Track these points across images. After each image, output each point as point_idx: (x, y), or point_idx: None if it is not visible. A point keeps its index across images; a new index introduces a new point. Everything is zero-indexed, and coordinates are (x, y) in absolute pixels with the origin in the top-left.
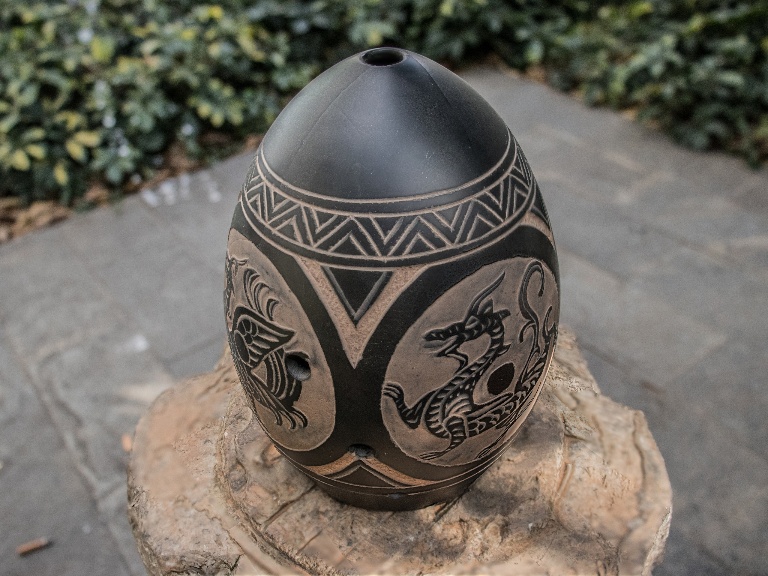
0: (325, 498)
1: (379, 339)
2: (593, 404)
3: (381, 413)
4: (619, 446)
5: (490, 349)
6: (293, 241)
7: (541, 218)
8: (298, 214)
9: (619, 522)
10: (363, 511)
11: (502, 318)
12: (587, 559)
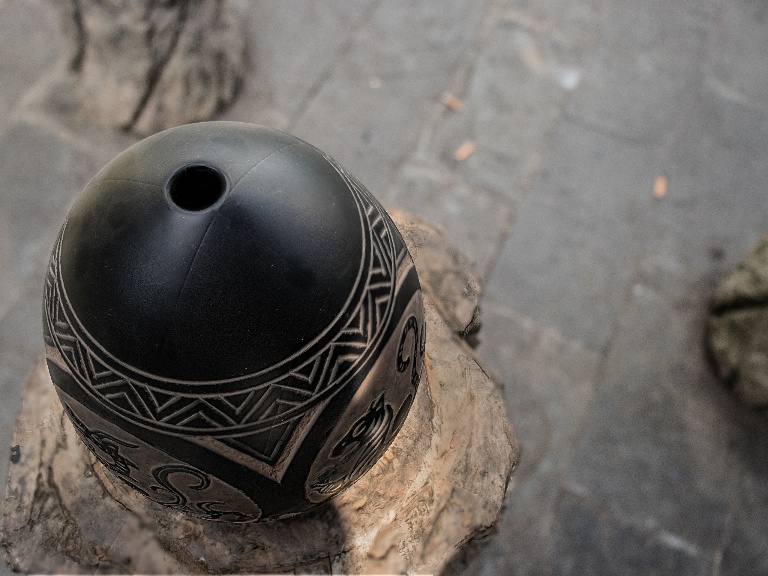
0: None
1: None
2: (387, 574)
3: None
4: None
5: (114, 466)
6: None
7: (244, 452)
8: None
9: None
10: None
11: (128, 464)
12: None
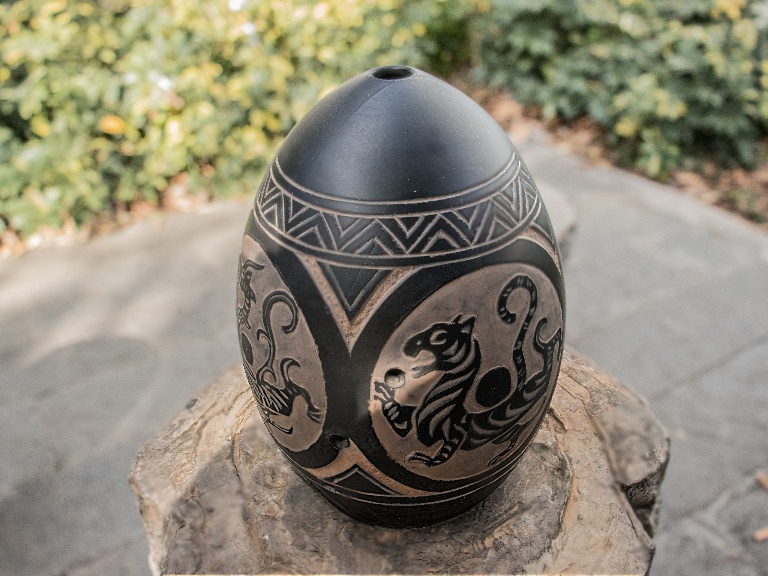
0: None
1: None
2: None
3: None
4: None
5: None
6: None
7: (333, 287)
8: None
9: None
10: None
11: None
12: None
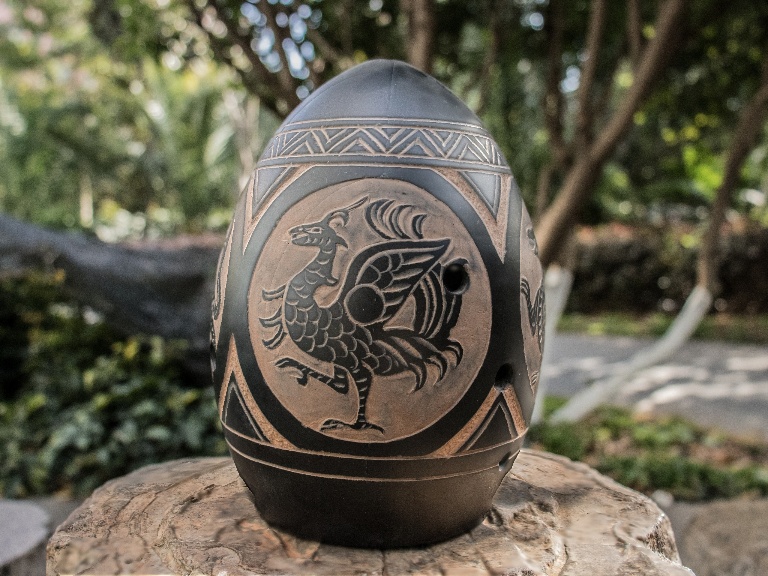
0: (405, 553)
1: (511, 232)
2: None
3: (520, 315)
4: (518, 457)
5: None
6: (425, 157)
7: None
8: (421, 136)
9: (582, 479)
10: (448, 543)
11: None
12: (602, 498)
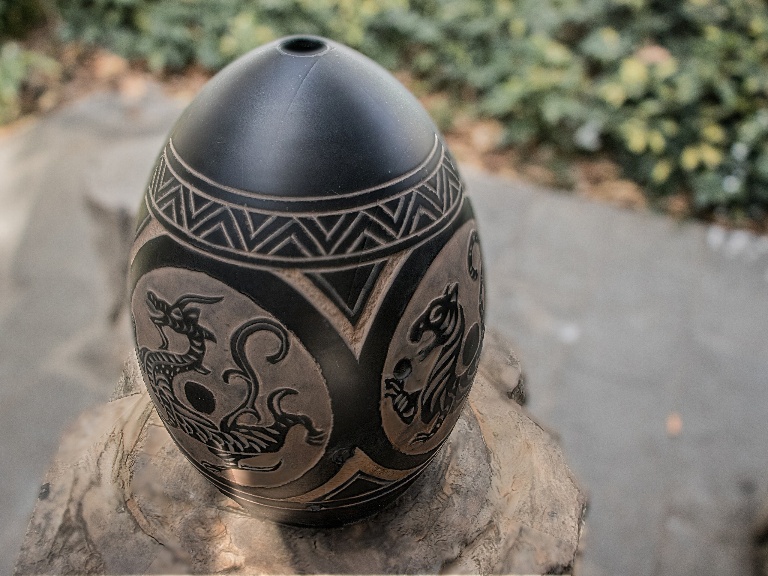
0: None
1: None
2: None
3: None
4: None
5: (188, 355)
6: None
7: (329, 296)
8: None
9: None
10: None
11: (206, 337)
12: None
